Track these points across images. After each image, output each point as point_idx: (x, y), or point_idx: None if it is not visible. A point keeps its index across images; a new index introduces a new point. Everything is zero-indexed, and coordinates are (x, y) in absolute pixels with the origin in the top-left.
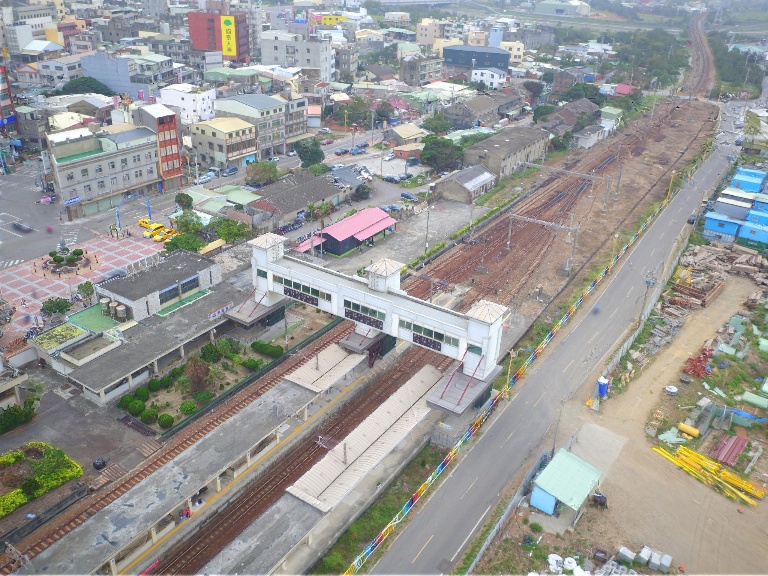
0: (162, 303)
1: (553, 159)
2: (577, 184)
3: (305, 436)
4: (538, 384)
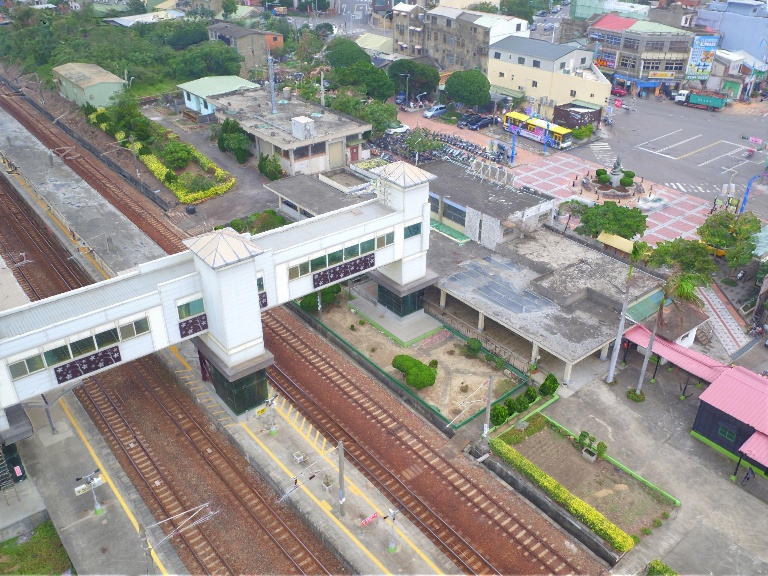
0: None
1: None
2: None
3: None
4: None
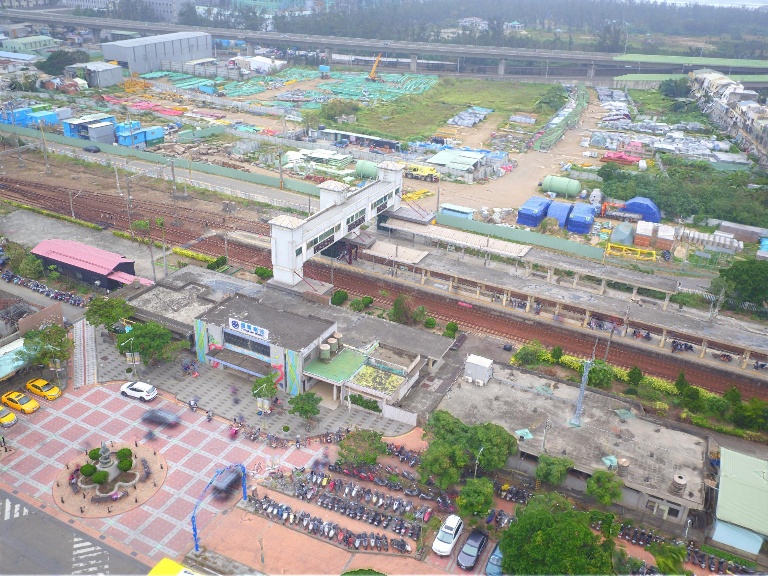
0: None
1: None
2: None
3: None
4: None
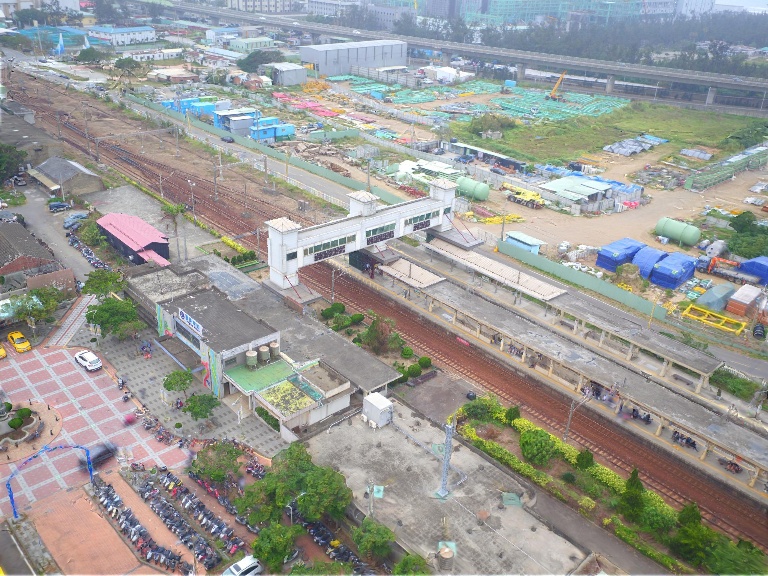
0: None
1: None
2: (110, 149)
3: None
4: None
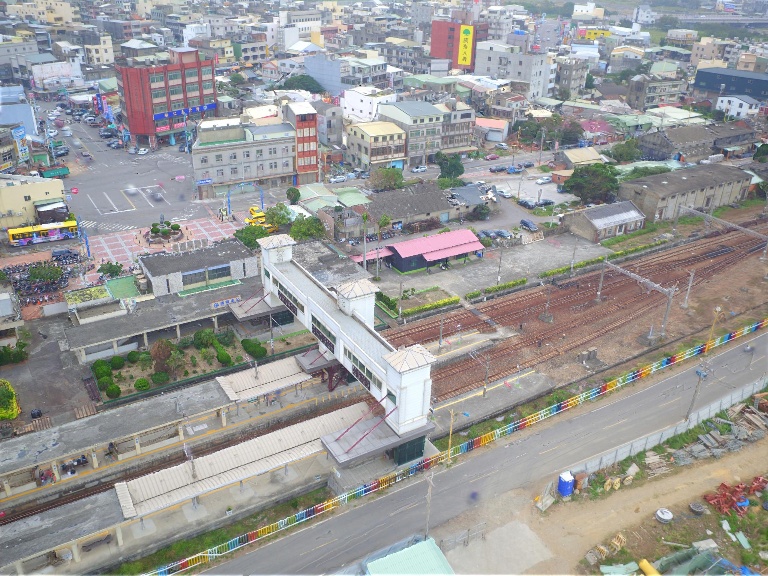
0: (186, 284)
1: (747, 208)
2: (757, 241)
3: (214, 441)
4: (497, 459)
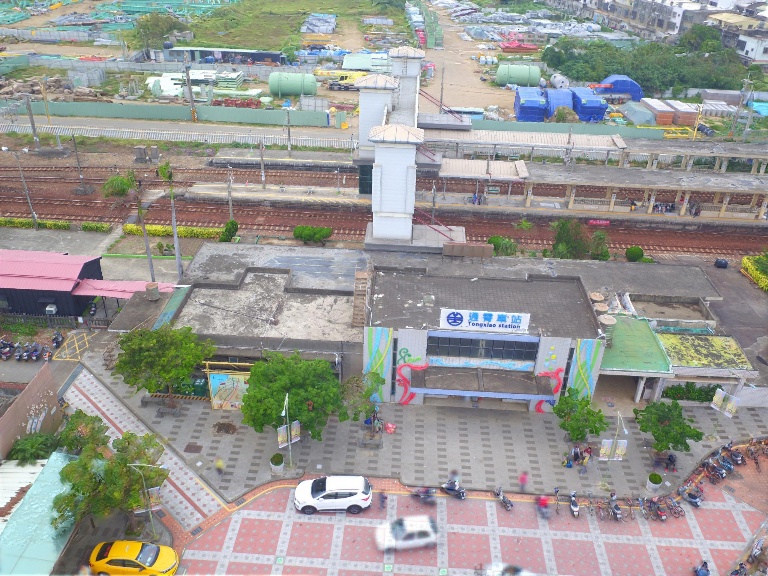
0: None
1: None
2: None
3: None
4: None
